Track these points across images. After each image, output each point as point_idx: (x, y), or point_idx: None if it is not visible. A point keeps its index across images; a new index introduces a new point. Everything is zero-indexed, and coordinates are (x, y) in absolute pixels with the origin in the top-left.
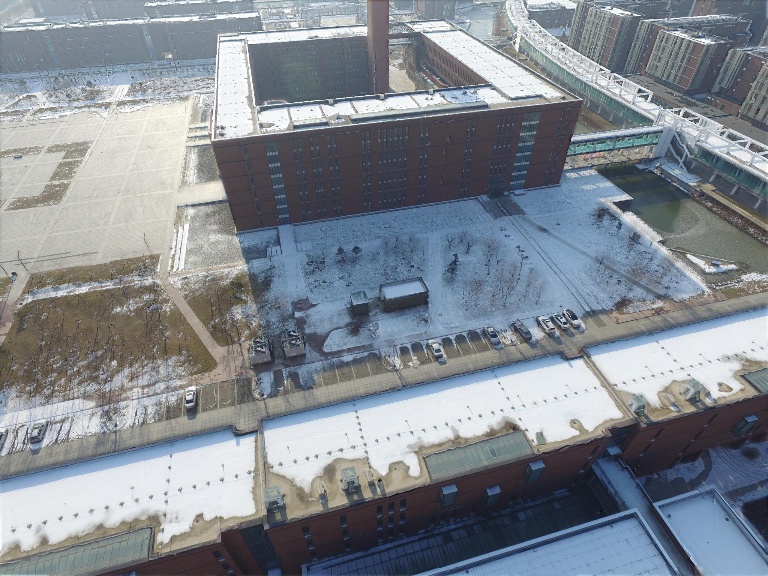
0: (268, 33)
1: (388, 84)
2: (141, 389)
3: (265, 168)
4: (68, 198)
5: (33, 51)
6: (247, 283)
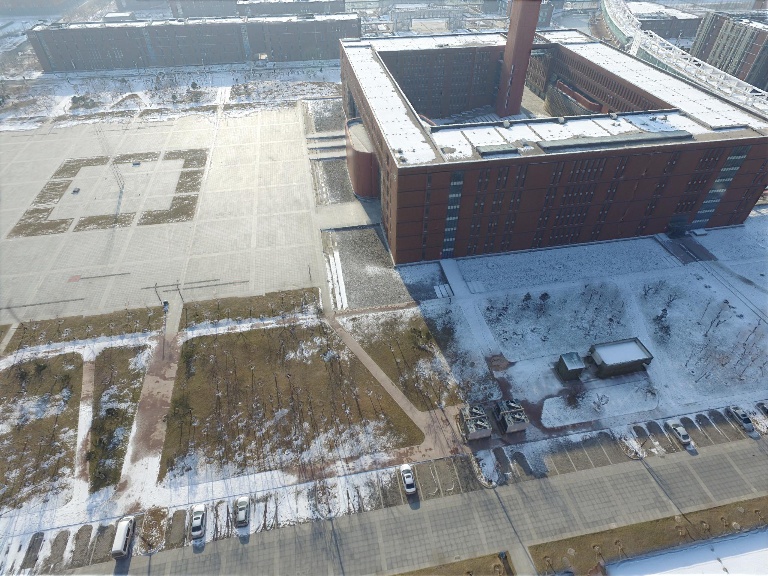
0: (391, 39)
1: (521, 99)
2: (345, 462)
3: (444, 198)
4: (200, 214)
5: (131, 48)
6: (426, 330)
